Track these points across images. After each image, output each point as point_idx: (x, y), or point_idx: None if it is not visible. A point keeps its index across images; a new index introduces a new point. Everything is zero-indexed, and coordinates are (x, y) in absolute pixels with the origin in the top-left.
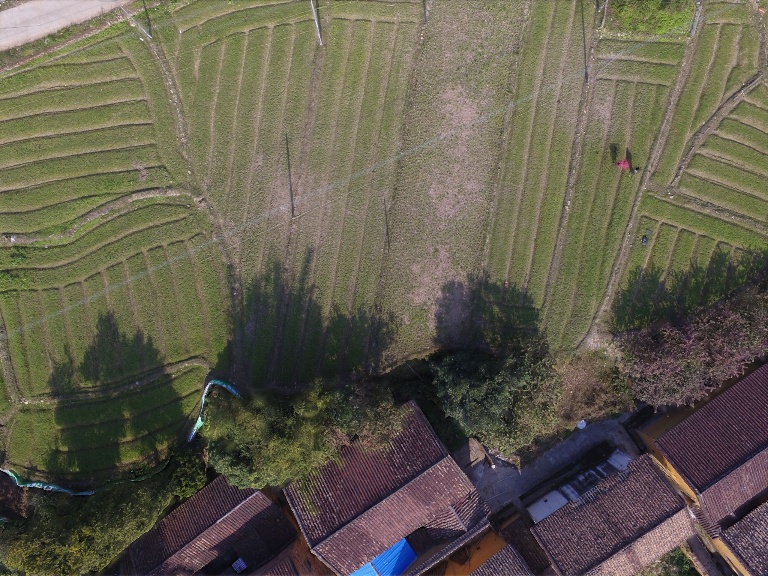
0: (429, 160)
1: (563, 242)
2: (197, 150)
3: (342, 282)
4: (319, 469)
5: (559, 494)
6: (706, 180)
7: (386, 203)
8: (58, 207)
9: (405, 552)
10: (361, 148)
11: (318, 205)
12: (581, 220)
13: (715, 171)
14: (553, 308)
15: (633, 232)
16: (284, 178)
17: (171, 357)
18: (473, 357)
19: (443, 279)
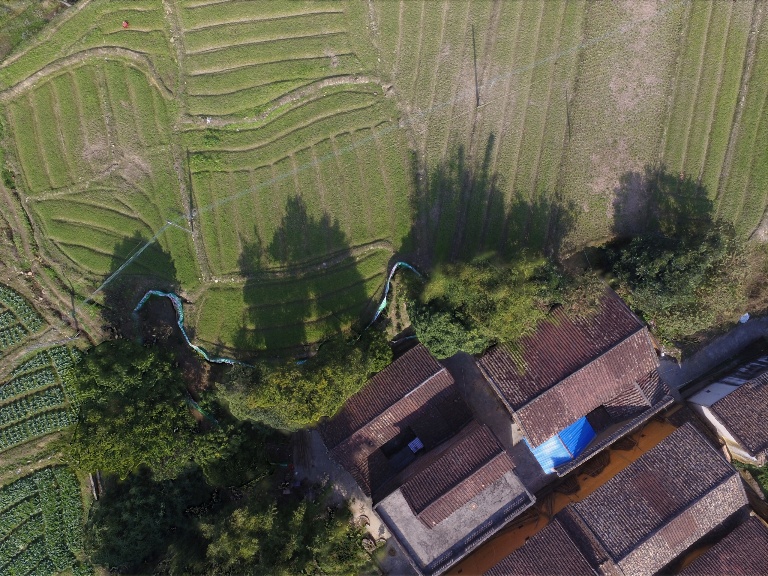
0: (609, 54)
1: (736, 137)
2: (387, 39)
3: (524, 170)
4: (511, 343)
5: (723, 384)
6: None
7: (567, 95)
8: (252, 90)
9: (586, 429)
10: (544, 41)
11: (502, 95)
12: (755, 115)
13: None
14: (726, 200)
15: None
16: (470, 68)
17: (357, 239)
18: None
19: (621, 169)
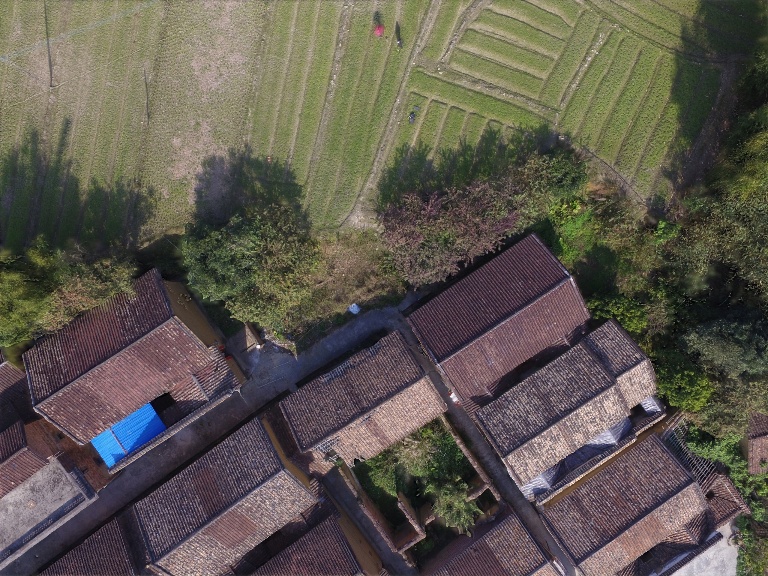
0: (191, 31)
1: (328, 118)
2: None
3: (100, 154)
4: (58, 335)
5: None
6: (478, 56)
7: (146, 74)
8: None
9: (154, 424)
10: (121, 17)
11: (77, 75)
12: (346, 95)
13: (487, 47)
14: (316, 184)
15: (401, 109)
16: (42, 47)
17: None
18: (219, 226)
19: (204, 153)
